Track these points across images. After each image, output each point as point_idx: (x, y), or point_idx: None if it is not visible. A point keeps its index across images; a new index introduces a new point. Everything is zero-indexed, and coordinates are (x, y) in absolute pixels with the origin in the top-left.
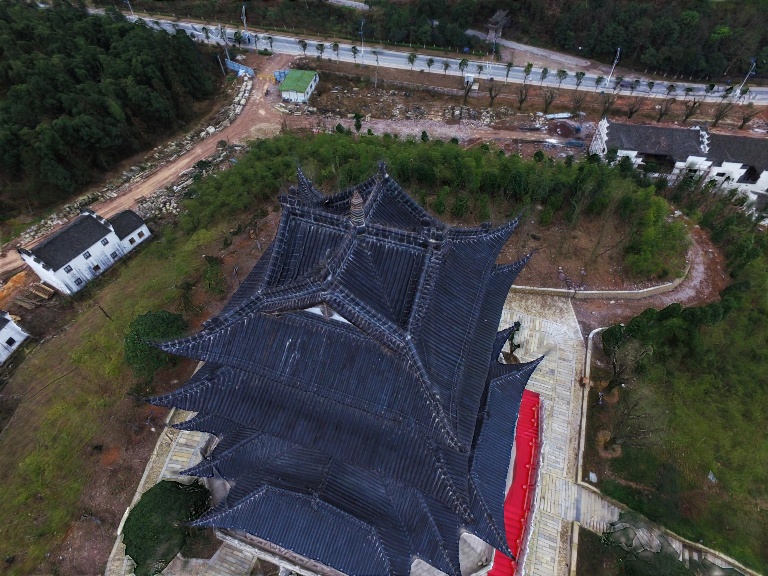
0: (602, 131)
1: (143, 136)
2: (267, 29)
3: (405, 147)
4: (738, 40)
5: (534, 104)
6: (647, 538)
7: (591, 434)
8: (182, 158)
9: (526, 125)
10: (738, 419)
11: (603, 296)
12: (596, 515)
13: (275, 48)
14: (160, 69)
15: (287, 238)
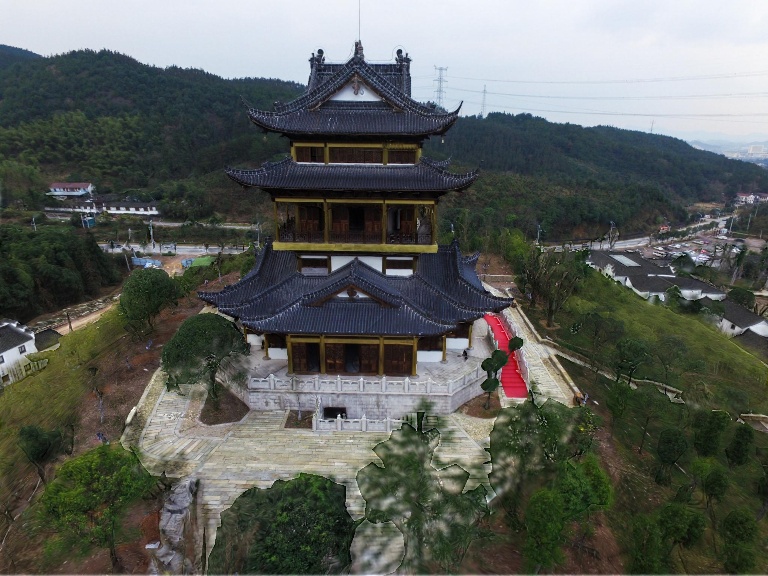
0: None
1: (48, 305)
2: (168, 243)
3: None
4: (524, 220)
5: None
6: (608, 377)
7: (534, 321)
8: (95, 313)
9: None
10: (626, 315)
11: (504, 280)
12: None
13: (178, 252)
14: (71, 256)
15: (316, 83)
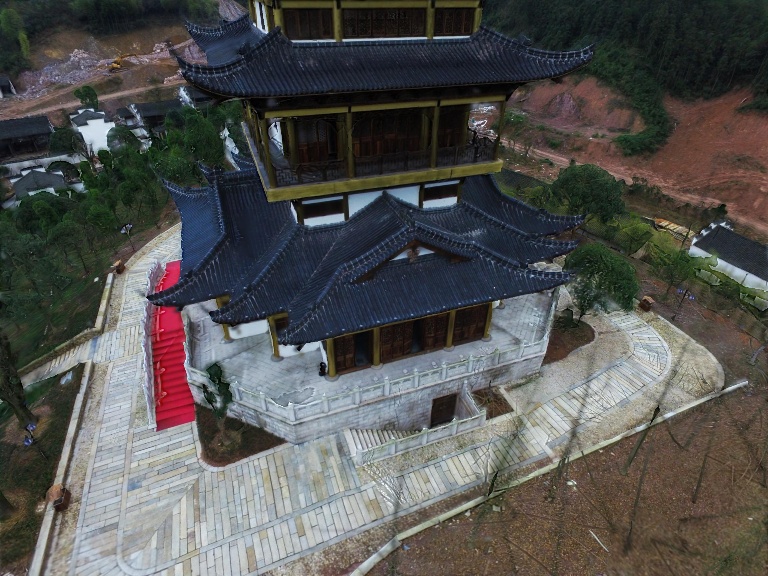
0: None
1: None
2: None
3: None
4: None
5: None
6: None
7: (60, 418)
8: None
9: None
10: None
11: None
12: (68, 362)
13: None
14: None
15: None
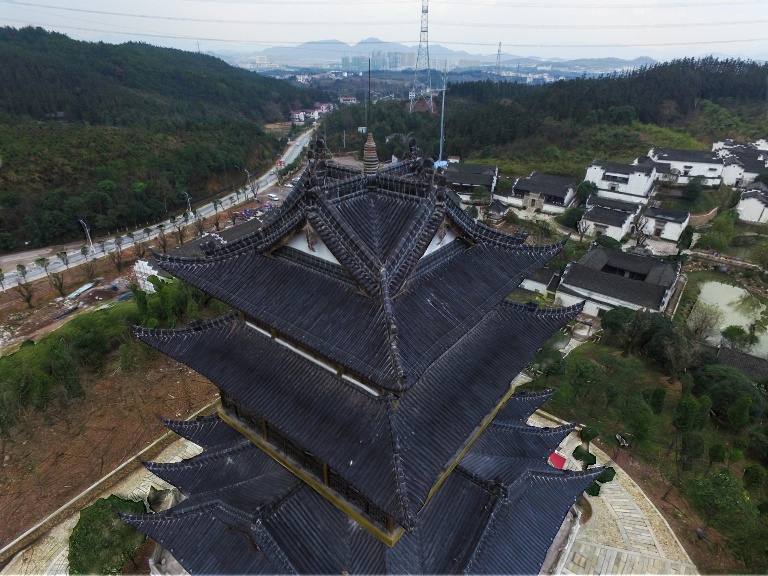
0: (145, 270)
1: None
2: None
3: (6, 358)
4: (156, 187)
5: (40, 298)
6: None
7: None
8: None
9: (58, 313)
10: None
11: None
12: None
13: None
14: None
15: None
